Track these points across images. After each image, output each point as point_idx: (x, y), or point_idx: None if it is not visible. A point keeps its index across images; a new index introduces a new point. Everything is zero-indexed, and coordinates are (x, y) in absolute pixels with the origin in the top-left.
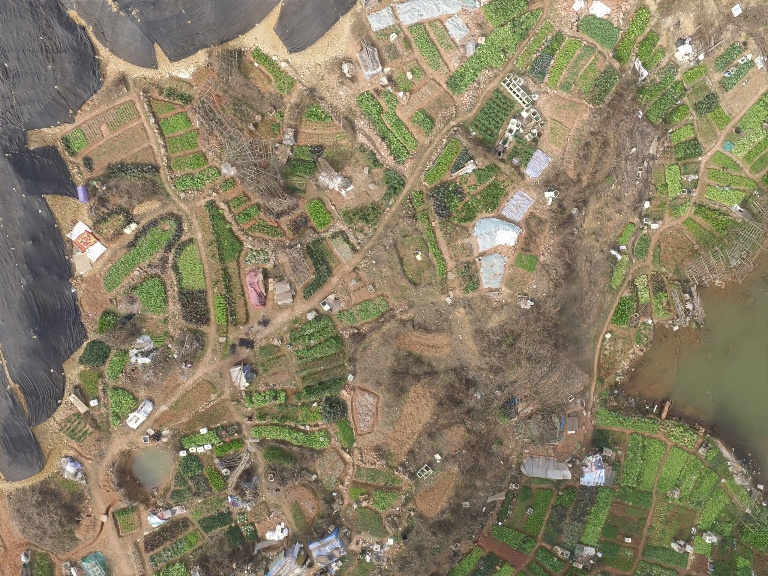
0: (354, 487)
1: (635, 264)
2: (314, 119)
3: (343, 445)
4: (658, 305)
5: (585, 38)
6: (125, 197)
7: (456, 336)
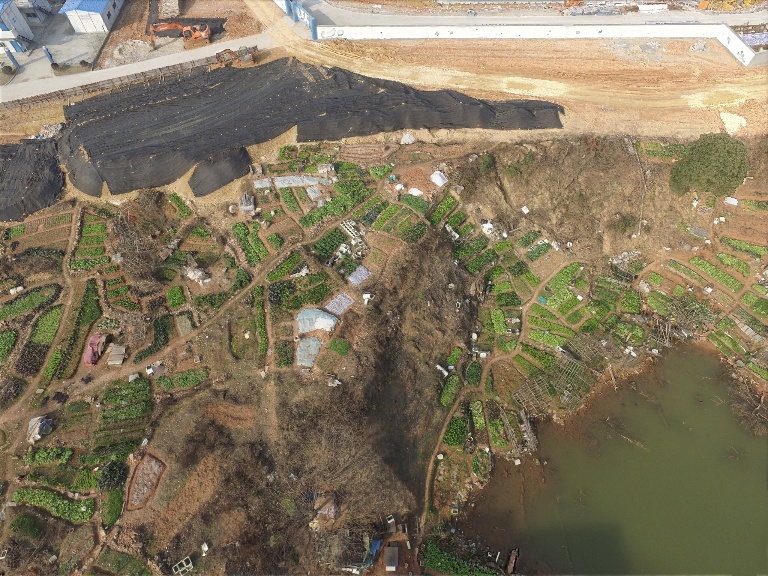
0: (91, 574)
1: (467, 387)
2: (197, 235)
3: (105, 521)
4: (494, 432)
5: (405, 206)
6: (27, 268)
7: (262, 410)
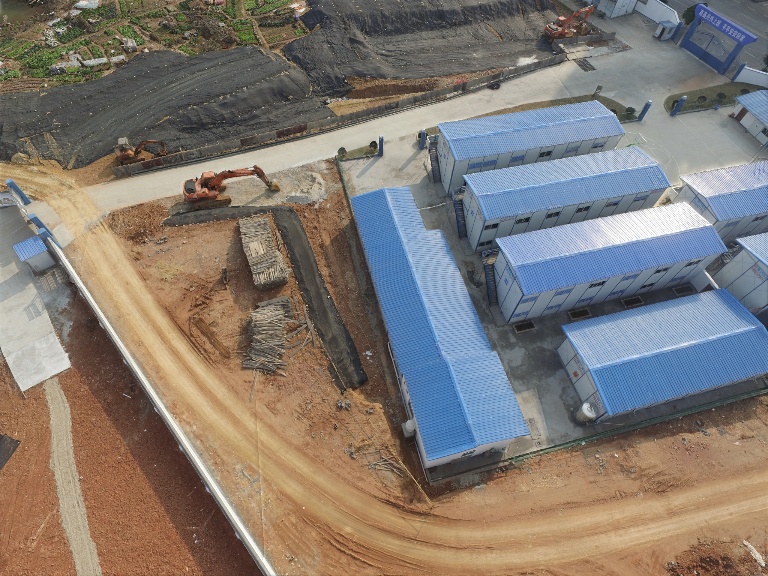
0: None
1: None
2: None
3: None
4: None
5: None
6: None
7: None
